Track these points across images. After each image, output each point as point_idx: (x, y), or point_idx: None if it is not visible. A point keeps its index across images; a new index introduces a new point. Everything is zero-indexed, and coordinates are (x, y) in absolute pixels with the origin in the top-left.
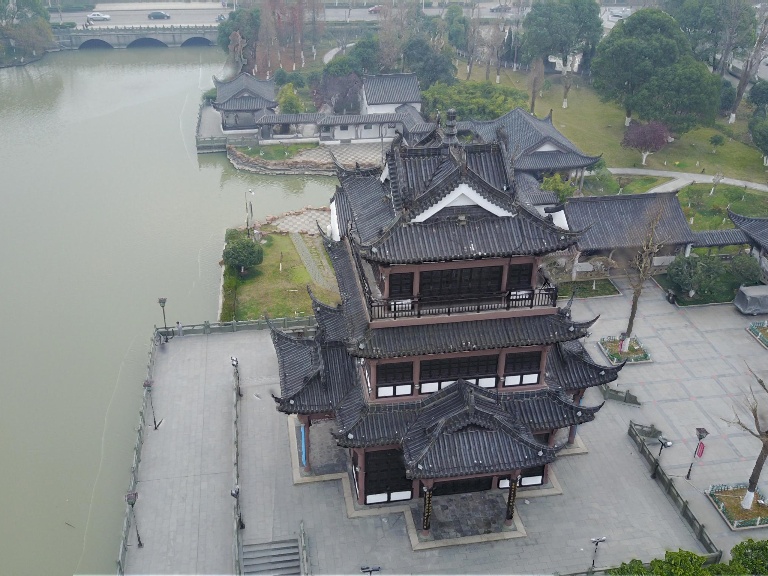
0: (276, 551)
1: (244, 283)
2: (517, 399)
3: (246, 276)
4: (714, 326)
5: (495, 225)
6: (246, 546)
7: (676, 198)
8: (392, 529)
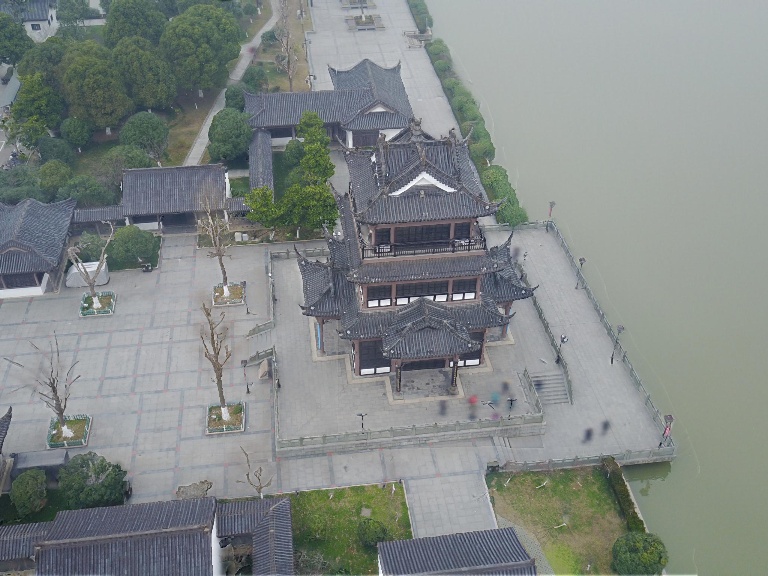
0: None
1: None
2: None
3: None
4: (115, 451)
5: None
6: None
7: None
8: None
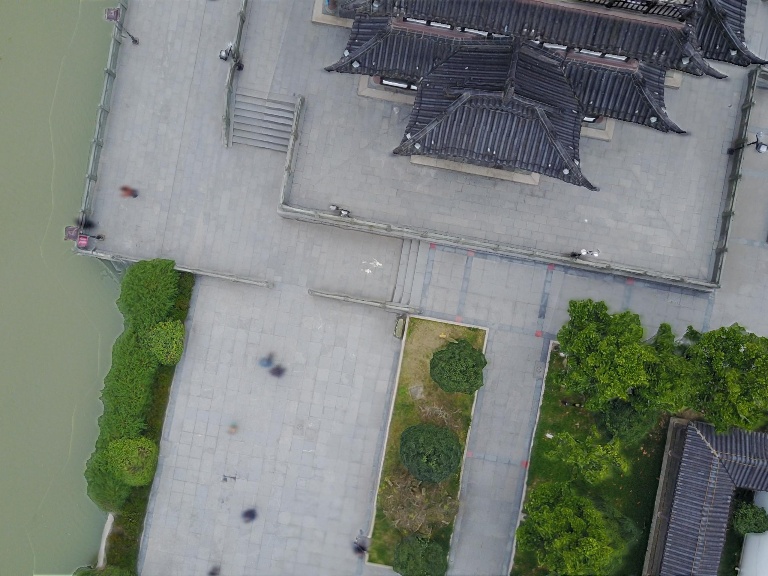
0: (270, 110)
1: None
2: (590, 67)
3: None
4: None
5: None
6: (239, 95)
7: None
8: (399, 125)
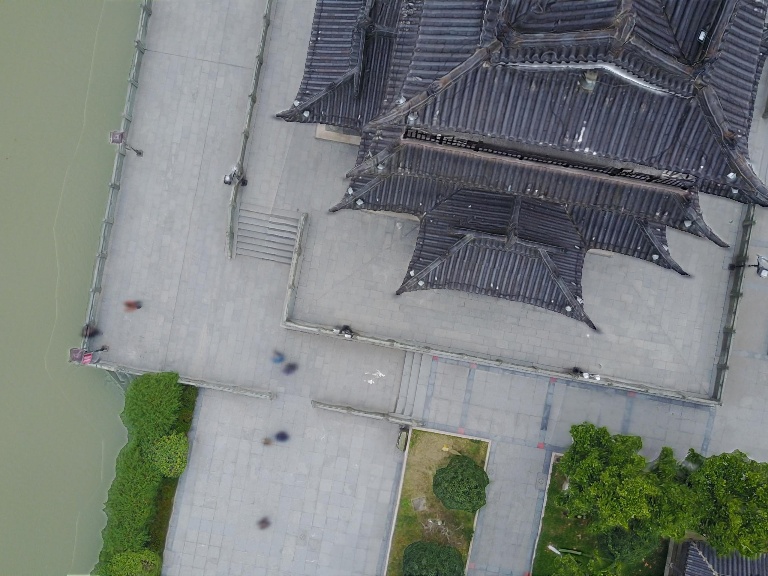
0: (273, 225)
1: None
2: None
3: None
4: None
5: (642, 102)
6: (243, 210)
7: None
8: (402, 241)
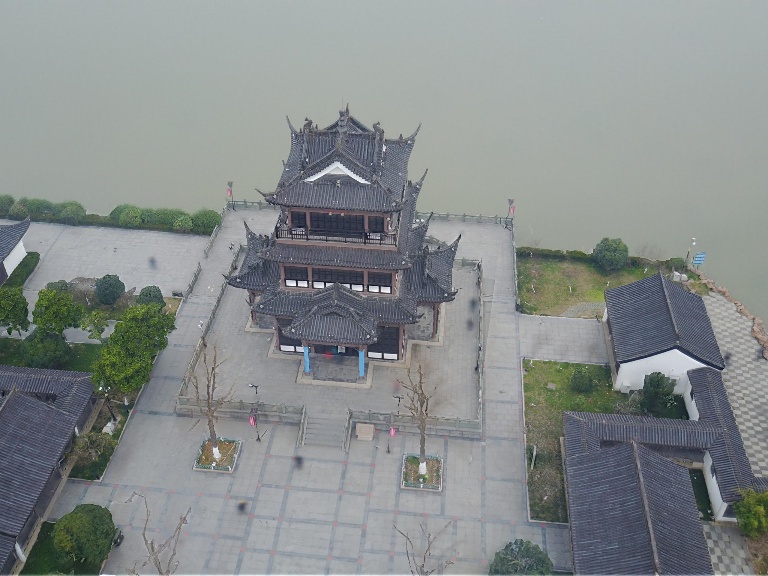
0: None
1: (589, 266)
2: None
3: (599, 267)
4: None
5: None
6: None
7: (653, 573)
8: None
